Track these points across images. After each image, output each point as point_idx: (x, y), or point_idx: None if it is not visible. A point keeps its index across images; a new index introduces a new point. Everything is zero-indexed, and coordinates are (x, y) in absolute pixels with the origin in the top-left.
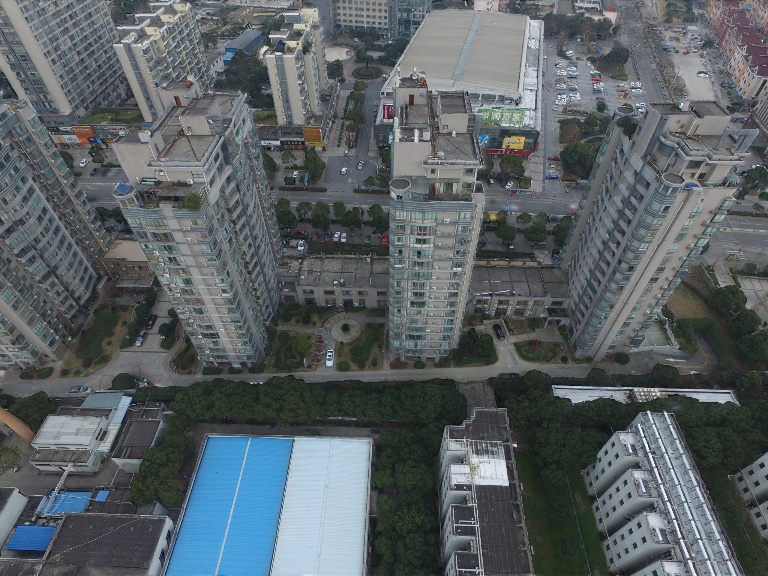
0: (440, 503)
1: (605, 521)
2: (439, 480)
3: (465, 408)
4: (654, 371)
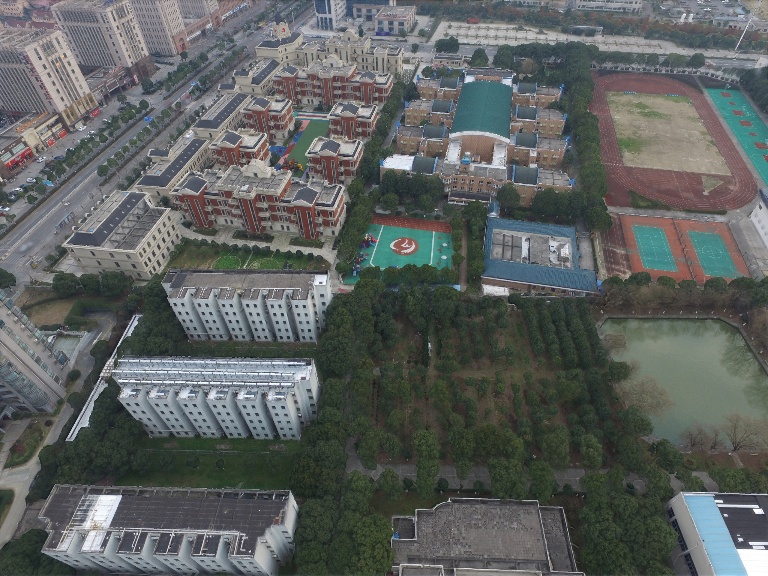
0: (123, 573)
1: (186, 430)
2: (102, 571)
3: (42, 532)
4: (95, 356)
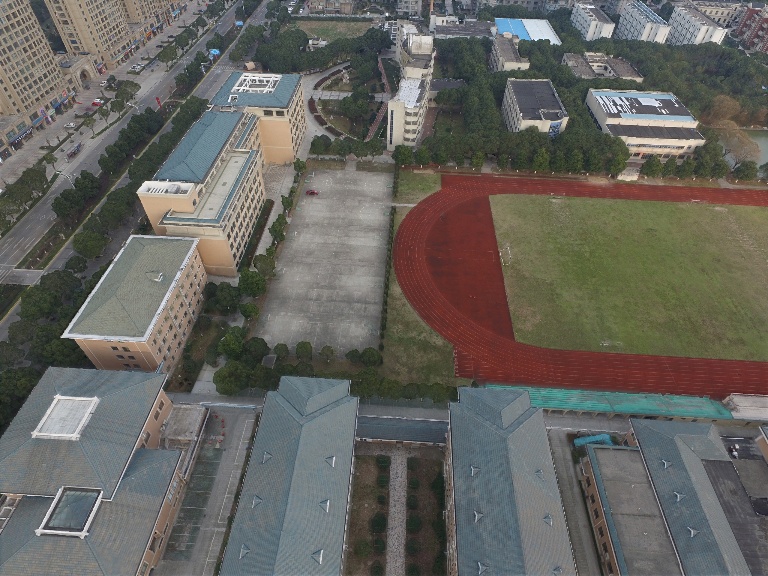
0: None
1: (621, 35)
2: None
3: None
4: None
